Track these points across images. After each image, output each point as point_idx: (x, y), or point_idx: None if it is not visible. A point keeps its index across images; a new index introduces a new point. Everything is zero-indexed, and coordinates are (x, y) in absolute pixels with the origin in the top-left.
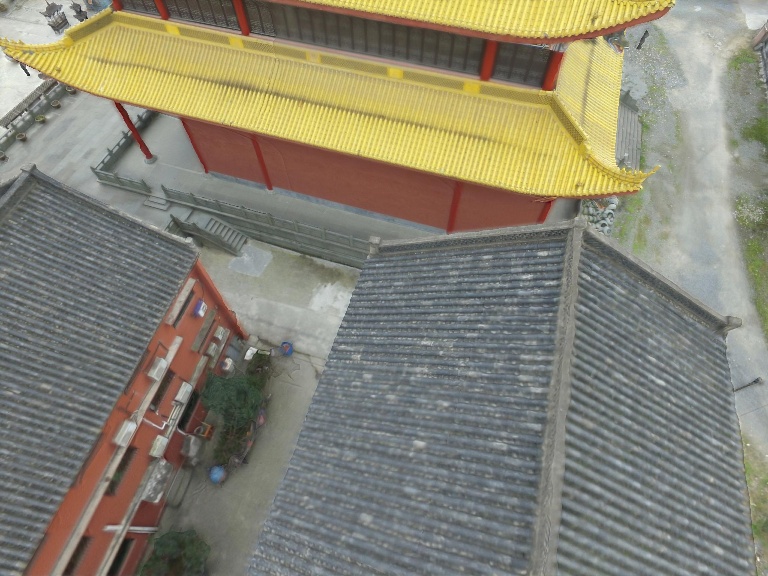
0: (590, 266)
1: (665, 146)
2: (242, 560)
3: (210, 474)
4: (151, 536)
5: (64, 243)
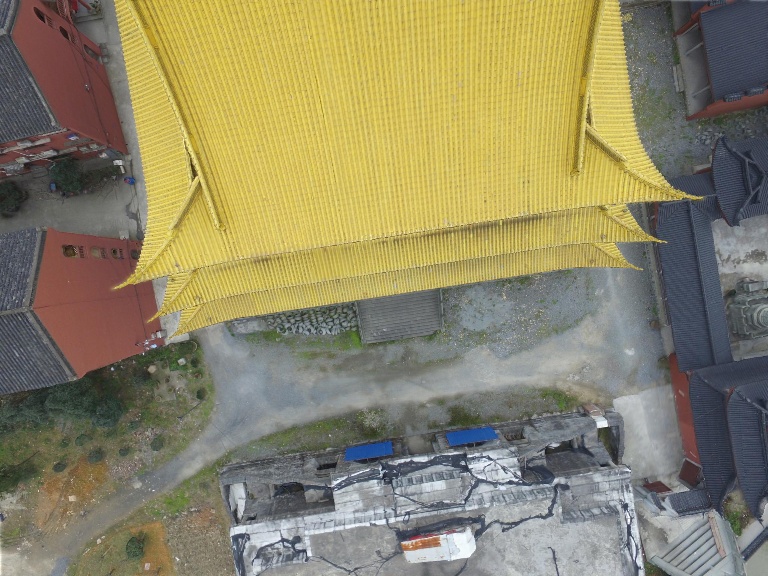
0: (27, 318)
1: (414, 355)
2: (31, 221)
3: (33, 189)
4: (15, 175)
5: (0, 74)
